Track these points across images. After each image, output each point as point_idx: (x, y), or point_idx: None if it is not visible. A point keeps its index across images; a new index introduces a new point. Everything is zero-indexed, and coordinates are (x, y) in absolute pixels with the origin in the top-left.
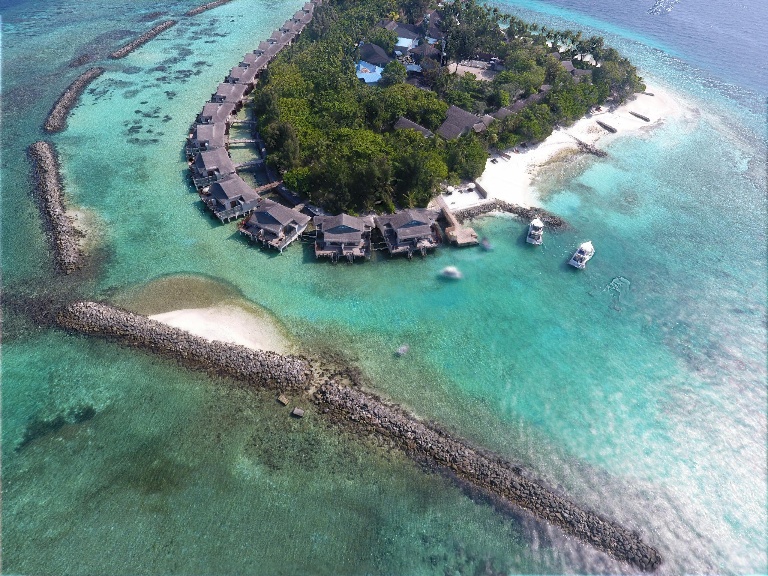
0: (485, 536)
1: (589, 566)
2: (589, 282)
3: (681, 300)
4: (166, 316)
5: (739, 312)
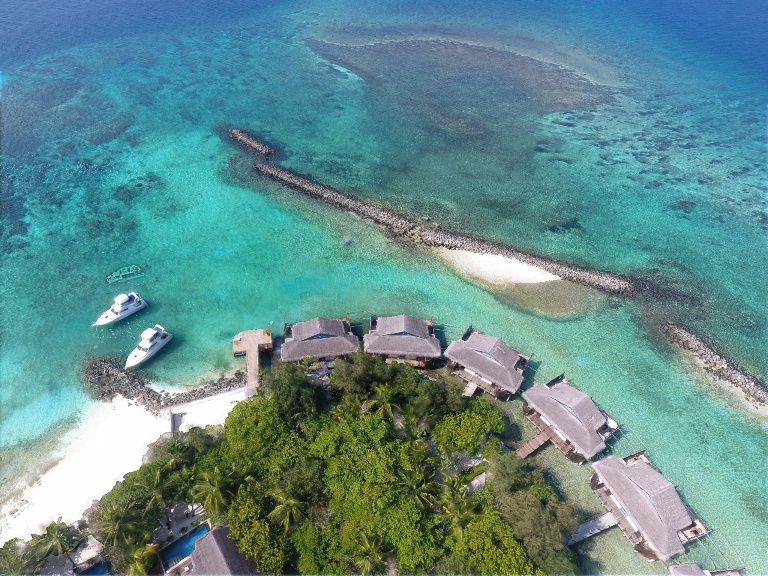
0: (330, 178)
1: (287, 168)
2: (144, 290)
3: (71, 268)
4: (546, 277)
5: (30, 256)
